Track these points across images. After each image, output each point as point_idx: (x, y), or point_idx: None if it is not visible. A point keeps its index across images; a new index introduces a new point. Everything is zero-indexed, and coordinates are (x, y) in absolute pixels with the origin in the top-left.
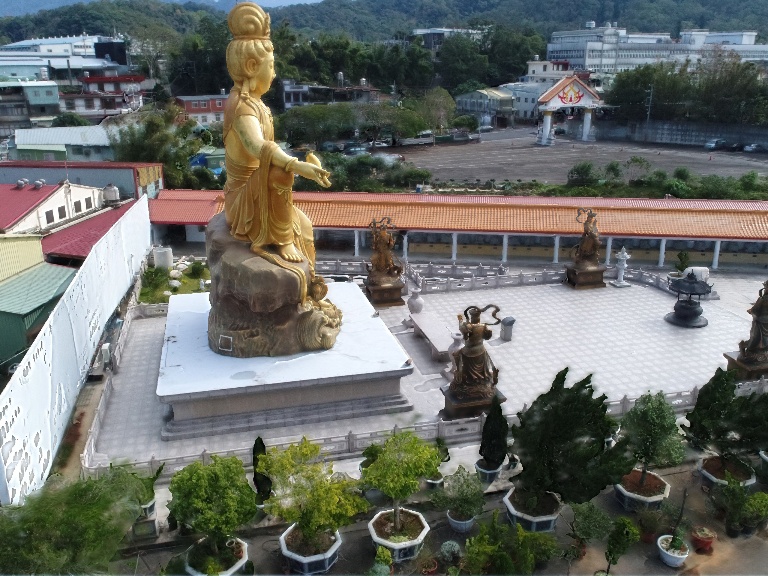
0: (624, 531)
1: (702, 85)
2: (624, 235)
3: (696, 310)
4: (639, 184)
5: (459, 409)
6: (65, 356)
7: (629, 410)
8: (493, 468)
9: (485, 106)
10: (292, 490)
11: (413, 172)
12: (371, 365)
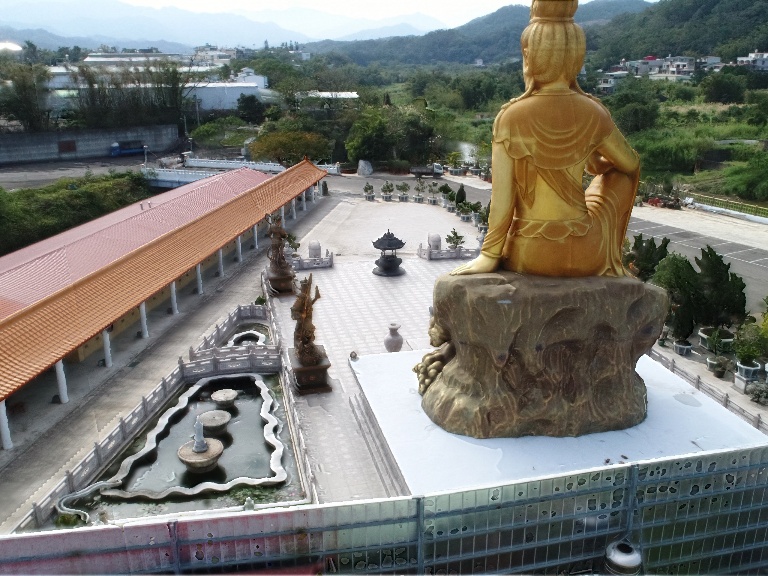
0: None
1: None
2: None
3: (400, 259)
4: None
5: None
6: None
7: None
8: (688, 342)
9: None
10: None
11: None
12: None
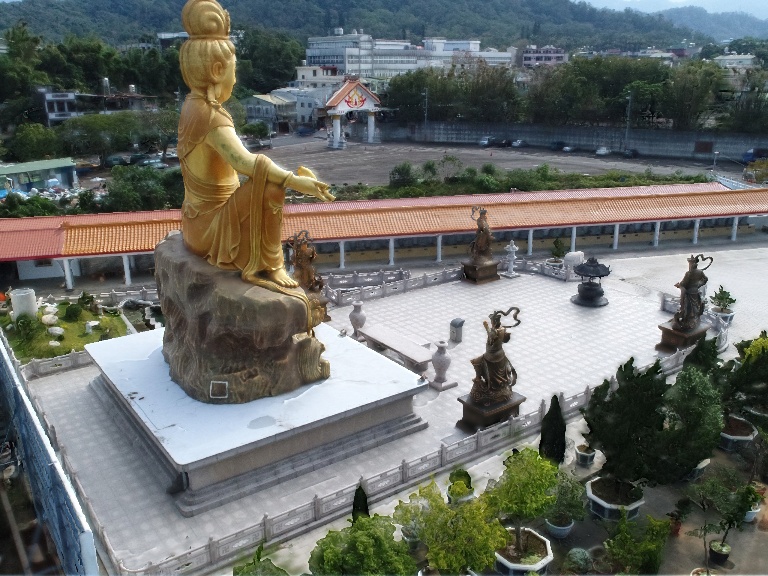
0: (749, 499)
1: (468, 88)
2: (500, 229)
3: (600, 290)
4: (454, 181)
5: (489, 416)
6: None
7: (615, 389)
8: None
9: (264, 112)
10: (450, 536)
11: None
12: (386, 387)
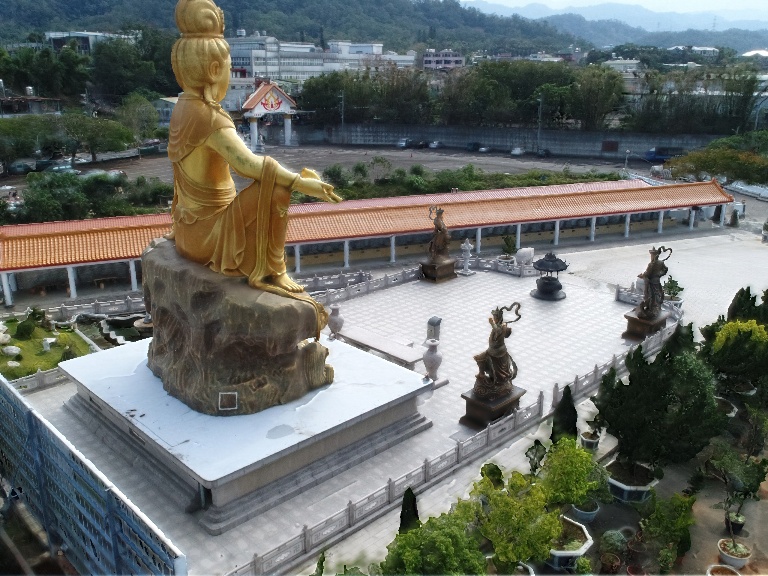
0: (765, 470)
1: (383, 90)
2: (451, 228)
3: (559, 284)
4: (384, 182)
5: (495, 411)
6: None
7: (598, 377)
8: None
9: None
10: (514, 528)
11: (162, 188)
12: (394, 388)
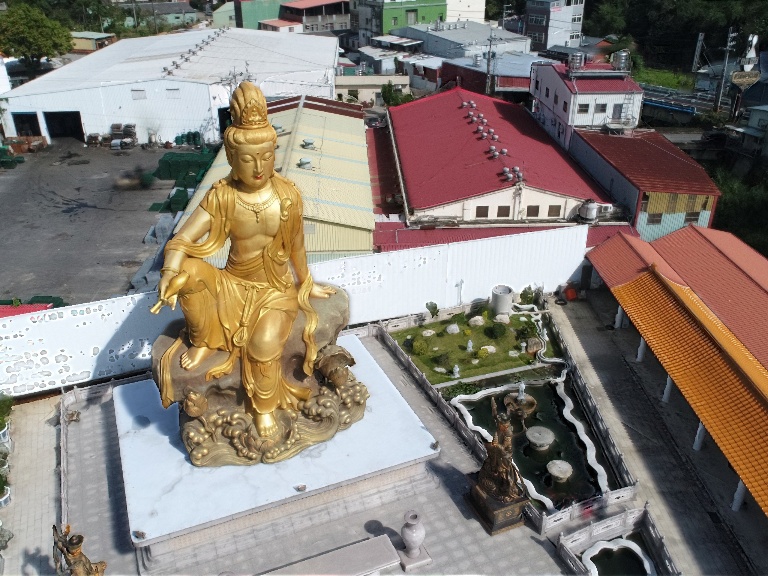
0: None
1: None
2: None
3: None
4: None
5: None
6: (165, 325)
7: None
8: None
9: None
10: None
11: None
12: (146, 505)
